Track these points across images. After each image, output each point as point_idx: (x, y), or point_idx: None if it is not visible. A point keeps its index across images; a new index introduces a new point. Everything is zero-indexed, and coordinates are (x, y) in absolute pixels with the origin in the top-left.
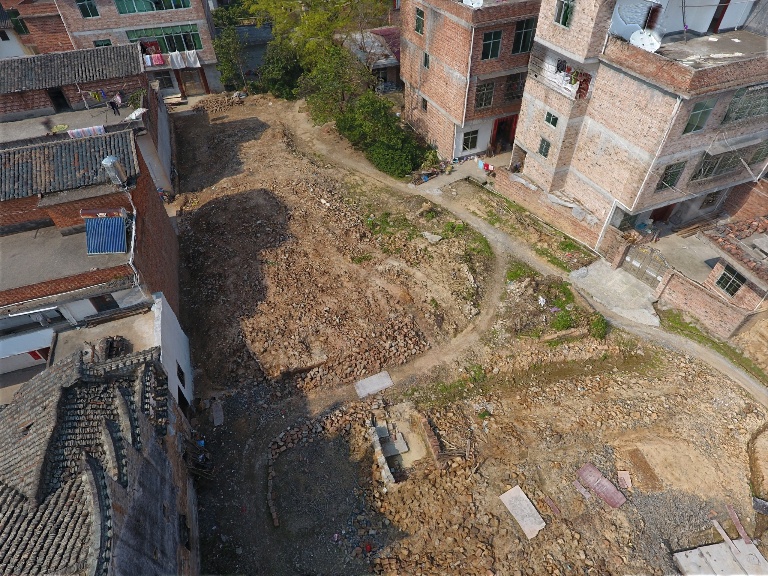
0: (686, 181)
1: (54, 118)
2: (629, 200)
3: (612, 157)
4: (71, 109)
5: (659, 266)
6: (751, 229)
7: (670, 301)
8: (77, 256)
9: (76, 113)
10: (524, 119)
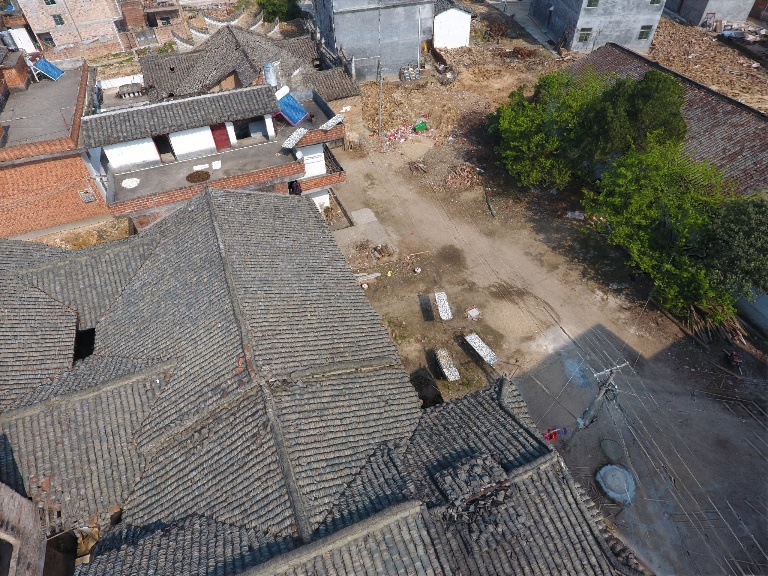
0: (117, 0)
1: None
2: (116, 13)
3: (92, 1)
4: None
5: (149, 31)
6: (150, 3)
7: (165, 41)
8: (55, 83)
9: None
10: (31, 15)
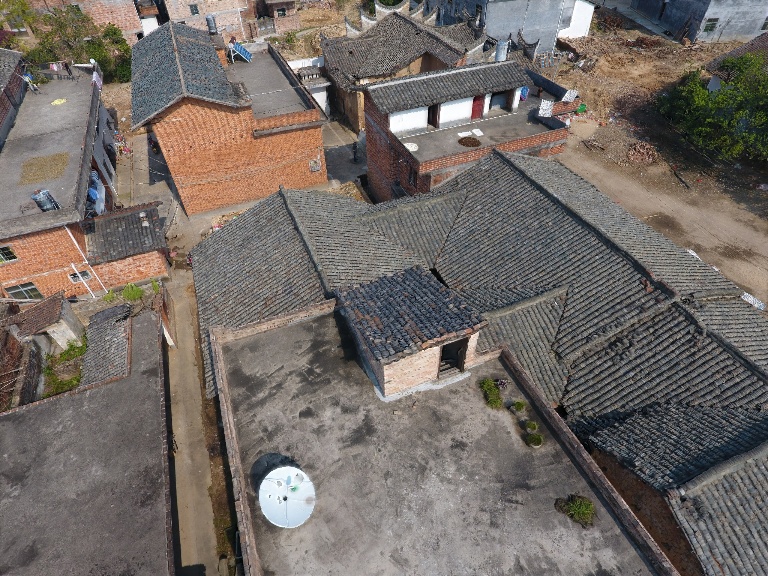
0: None
1: (29, 109)
2: (243, 4)
3: None
4: (15, 105)
5: (269, 22)
6: None
7: (281, 32)
8: (250, 64)
9: (27, 103)
10: (171, 4)
